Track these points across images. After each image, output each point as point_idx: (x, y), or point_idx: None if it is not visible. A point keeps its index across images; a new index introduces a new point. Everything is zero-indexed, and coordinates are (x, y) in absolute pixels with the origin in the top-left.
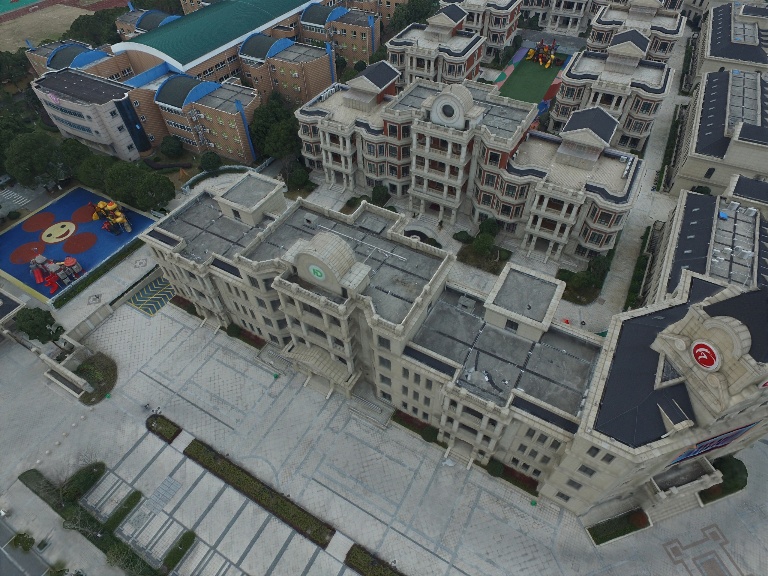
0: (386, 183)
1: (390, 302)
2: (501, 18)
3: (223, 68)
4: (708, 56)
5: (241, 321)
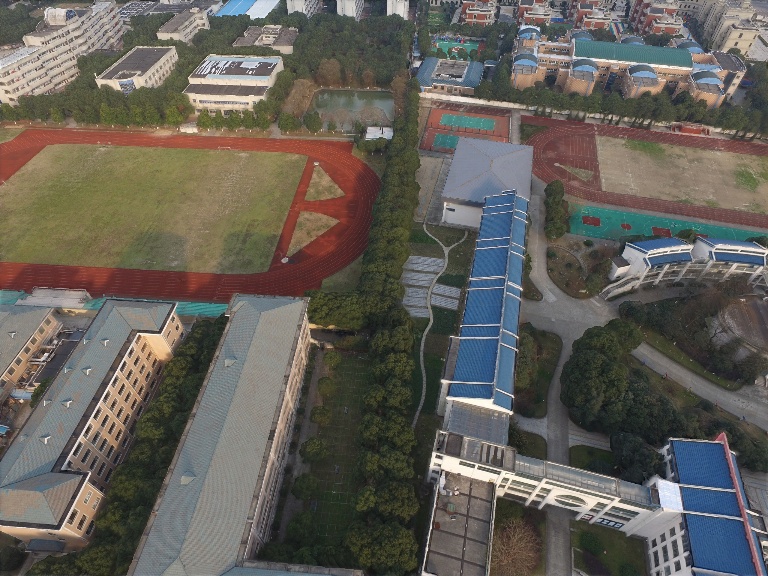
0: None
1: None
2: None
3: None
4: None
5: None
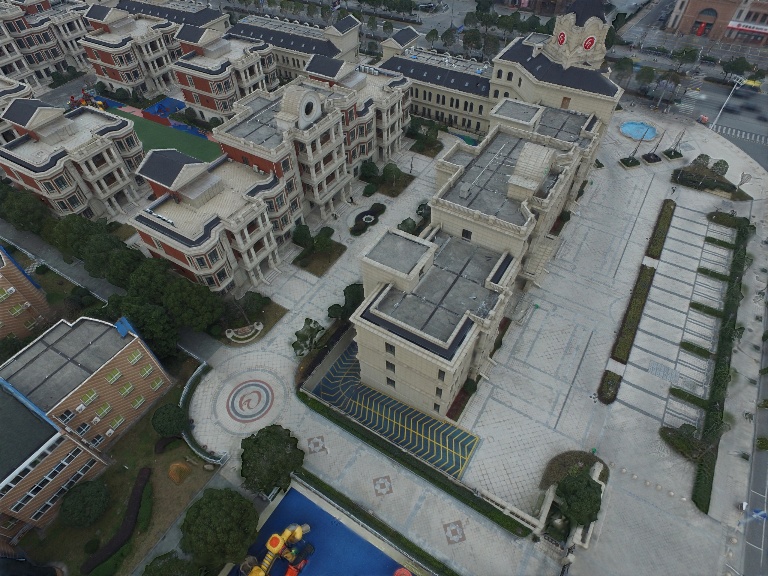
0: None
1: None
2: None
3: None
4: None
5: None
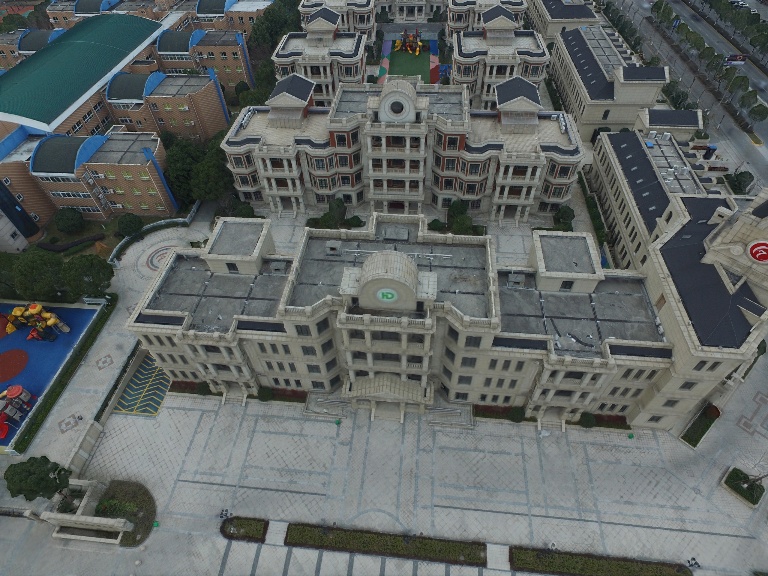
0: (339, 195)
1: (464, 300)
2: (365, 15)
3: (91, 119)
4: (551, 20)
5: (272, 380)
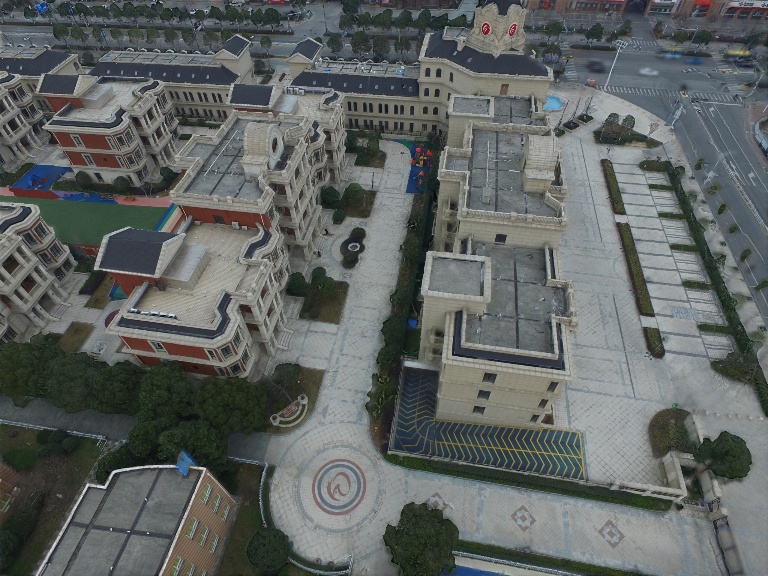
0: None
1: None
2: None
3: None
4: None
5: None
